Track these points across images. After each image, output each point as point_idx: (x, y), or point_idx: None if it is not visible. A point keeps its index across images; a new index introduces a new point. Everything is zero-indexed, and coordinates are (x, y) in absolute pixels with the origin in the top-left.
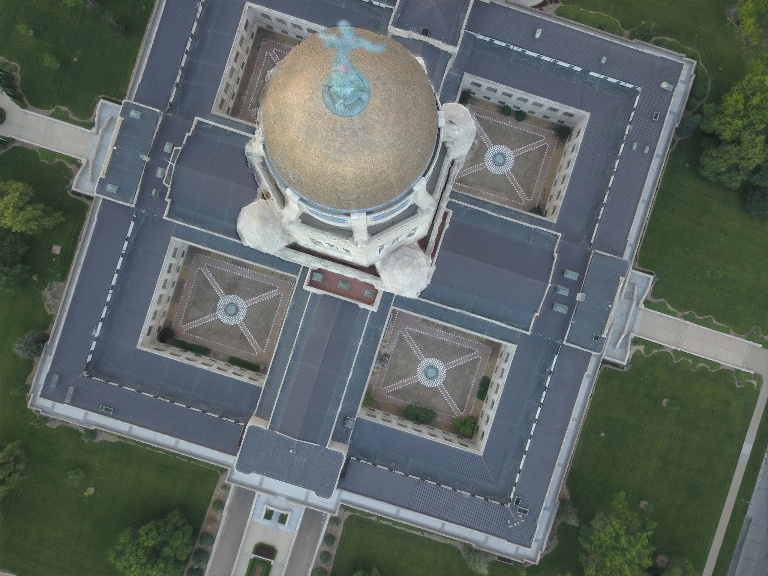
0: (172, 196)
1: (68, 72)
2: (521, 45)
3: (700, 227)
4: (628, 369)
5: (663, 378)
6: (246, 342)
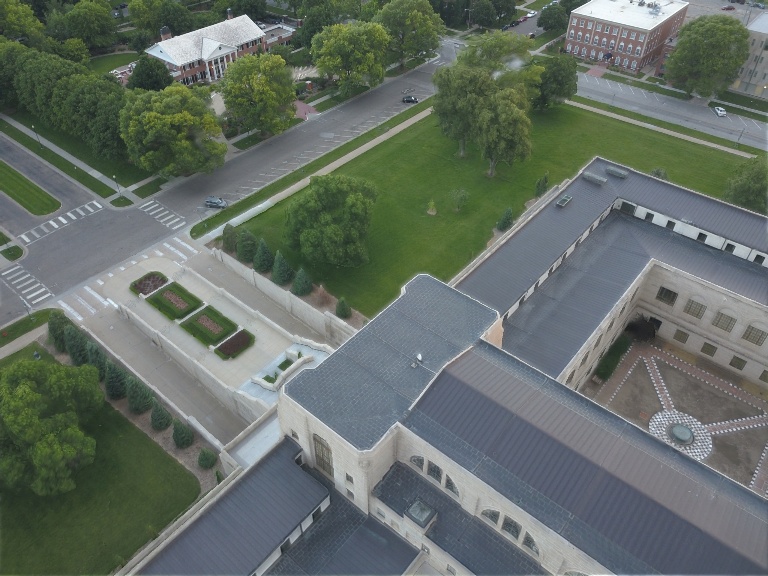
0: None
1: None
2: None
3: None
4: None
5: None
6: None
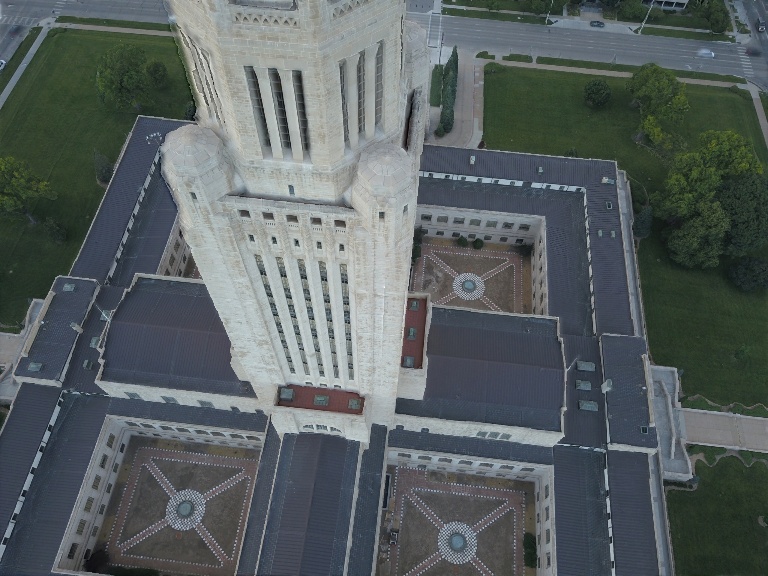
0: (107, 357)
1: (1, 284)
2: (459, 172)
3: (700, 314)
4: (698, 487)
5: (744, 490)
6: (207, 551)
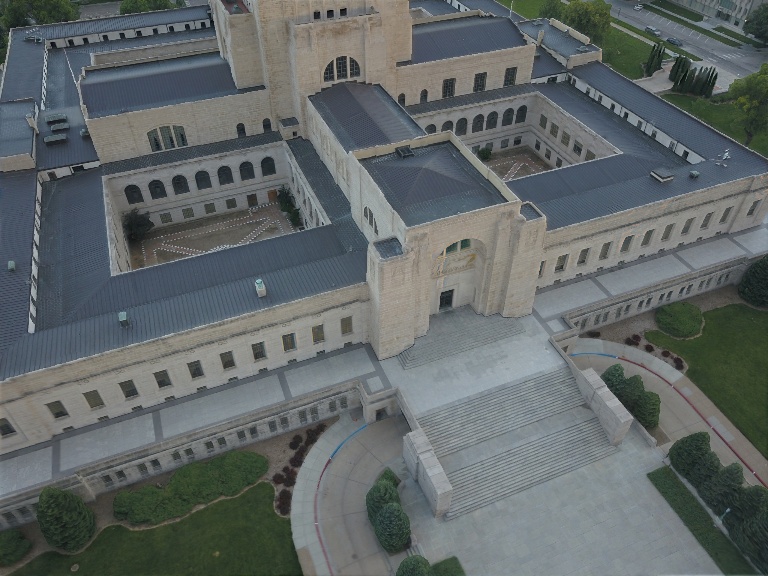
0: None
1: None
2: (277, 273)
3: None
4: None
5: None
6: None
